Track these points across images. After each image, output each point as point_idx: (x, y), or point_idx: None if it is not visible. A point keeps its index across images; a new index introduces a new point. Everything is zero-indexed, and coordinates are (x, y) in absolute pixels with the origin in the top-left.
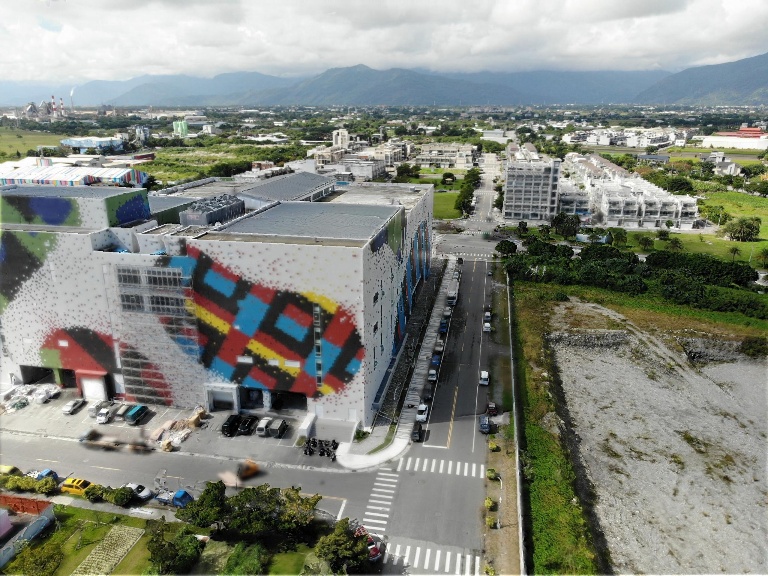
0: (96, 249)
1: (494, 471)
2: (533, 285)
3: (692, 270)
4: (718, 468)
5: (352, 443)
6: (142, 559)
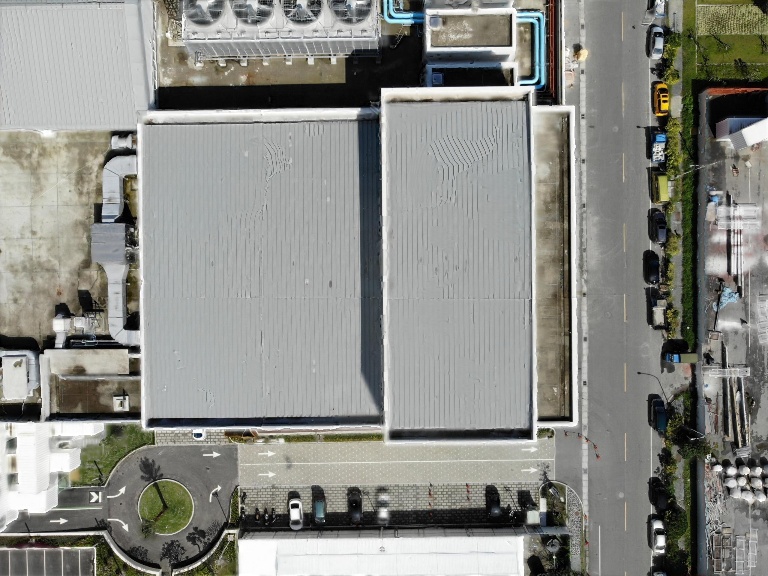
0: None
1: None
2: None
3: None
4: None
5: None
6: None
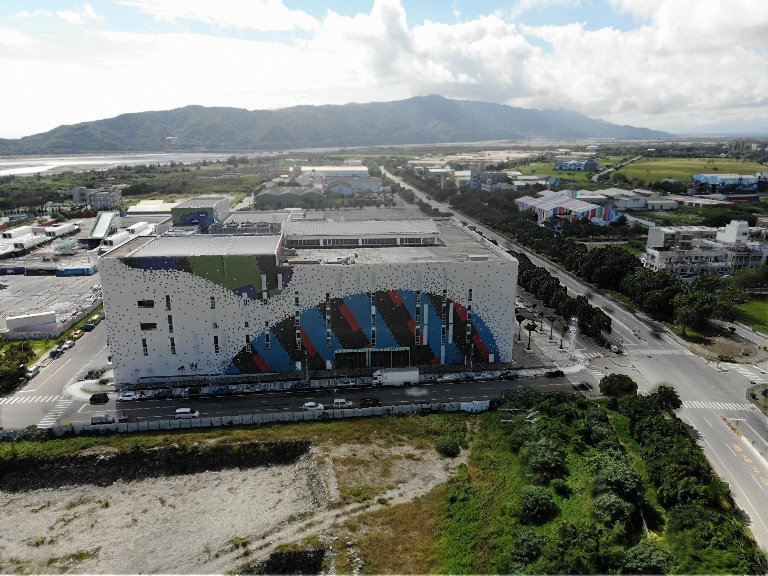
0: (160, 234)
1: (32, 427)
2: (485, 425)
3: (670, 573)
4: (15, 568)
5: (96, 382)
6: None
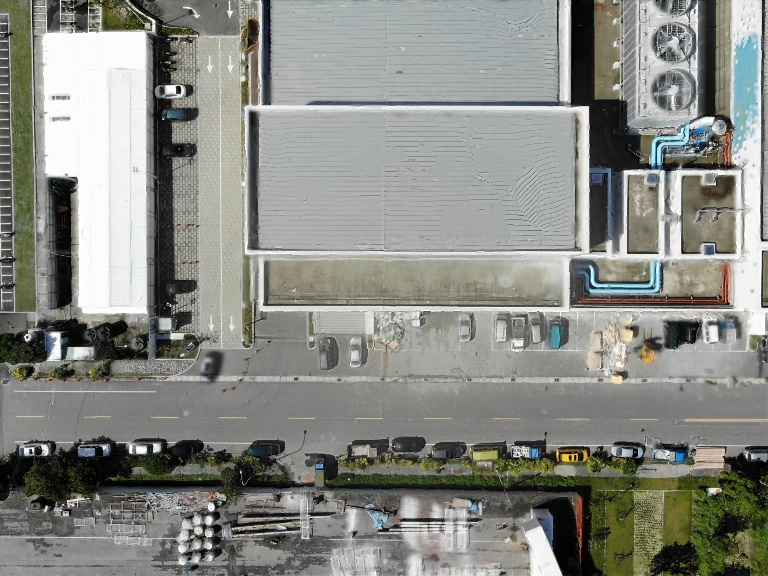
0: None
1: None
2: None
3: None
4: None
5: None
6: (680, 522)
